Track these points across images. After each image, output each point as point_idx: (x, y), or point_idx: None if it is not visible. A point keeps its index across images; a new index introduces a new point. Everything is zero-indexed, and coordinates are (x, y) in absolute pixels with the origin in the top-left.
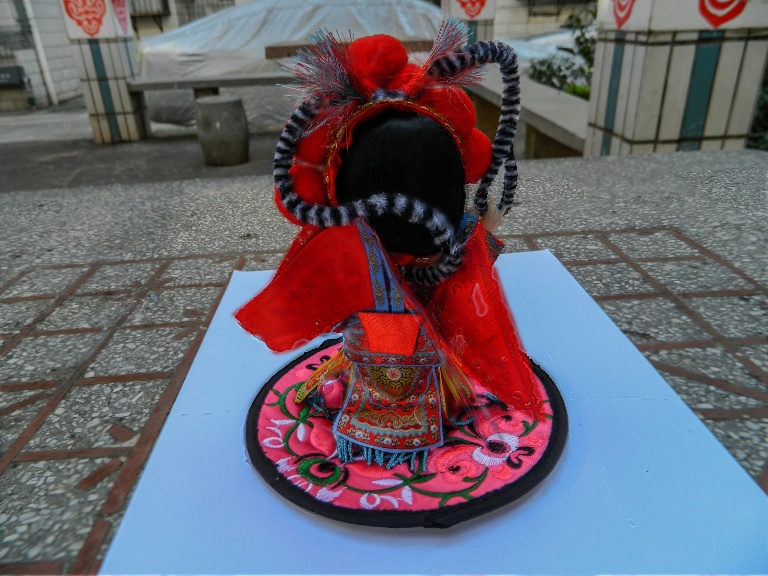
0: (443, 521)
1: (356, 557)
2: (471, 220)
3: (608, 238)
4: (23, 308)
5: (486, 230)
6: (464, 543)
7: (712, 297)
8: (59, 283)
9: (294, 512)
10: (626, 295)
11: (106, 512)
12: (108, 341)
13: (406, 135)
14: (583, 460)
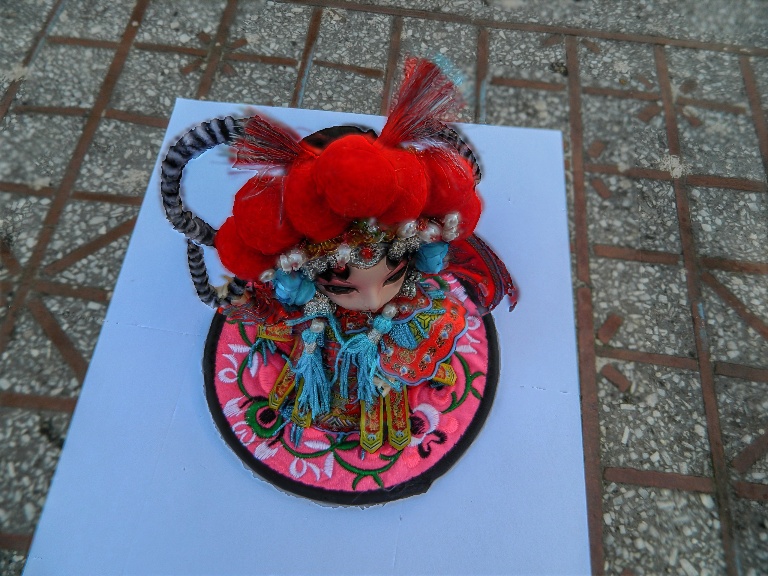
0: None
1: None
2: None
3: None
4: None
5: None
6: None
7: None
8: None
9: None
10: None
11: (587, 289)
12: None
13: None
14: None
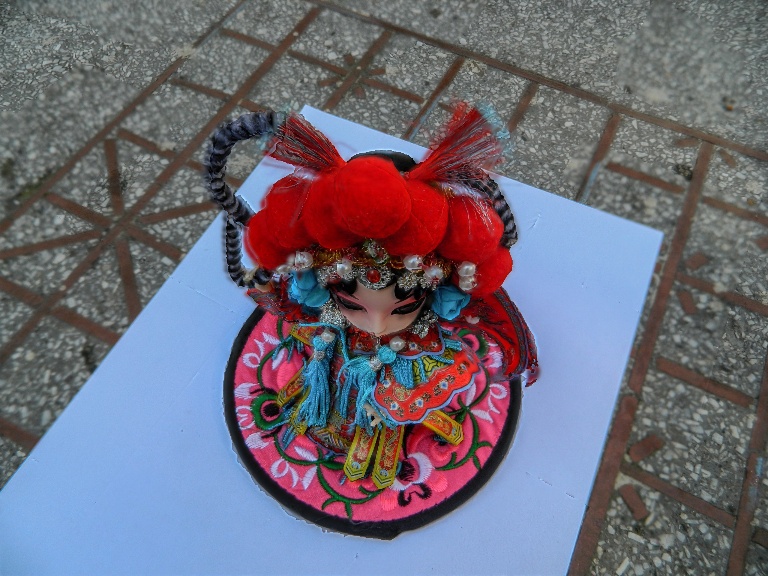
0: None
1: None
2: None
3: None
4: None
5: None
6: None
7: None
8: None
9: None
10: None
11: (634, 399)
12: None
13: None
14: None
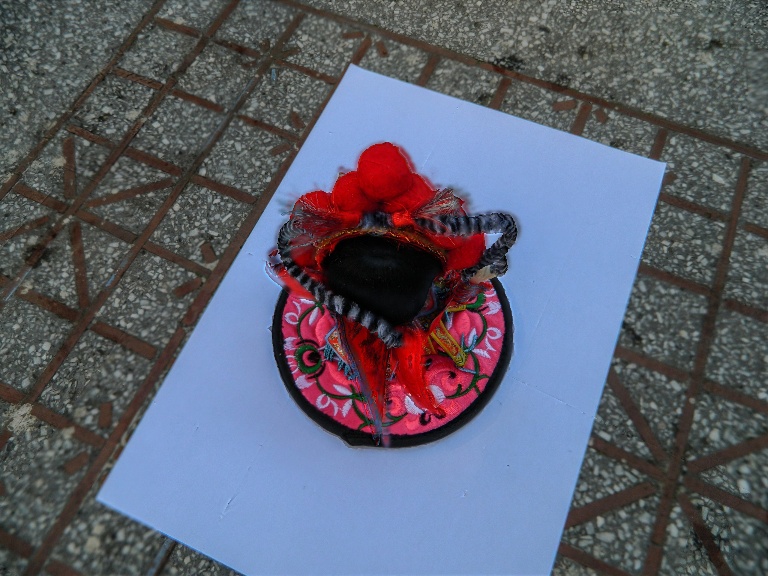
0: (352, 441)
1: (301, 429)
2: (632, 63)
3: (752, 169)
4: (173, 44)
5: (472, 283)
6: (362, 453)
7: (754, 319)
8: (206, 11)
9: (282, 381)
10: (674, 277)
11: (185, 323)
12: (224, 131)
13: (366, 281)
14: (476, 434)
